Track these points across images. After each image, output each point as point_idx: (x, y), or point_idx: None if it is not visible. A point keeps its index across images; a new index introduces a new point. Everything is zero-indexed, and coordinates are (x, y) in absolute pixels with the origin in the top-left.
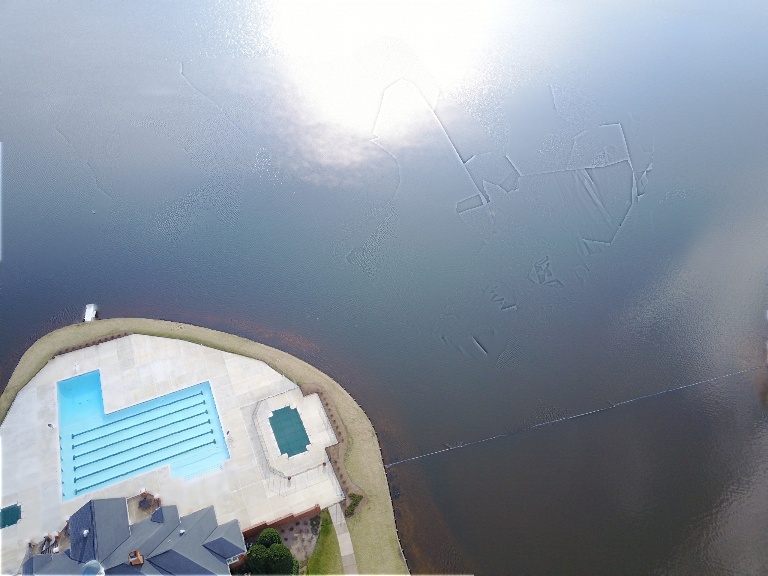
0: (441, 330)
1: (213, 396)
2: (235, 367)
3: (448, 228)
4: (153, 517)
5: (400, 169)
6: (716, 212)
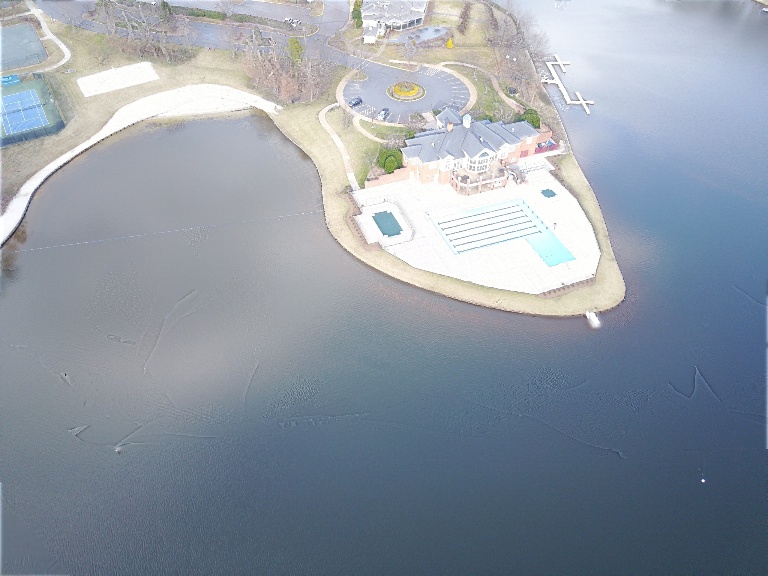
0: None
1: None
2: (436, 263)
3: None
4: None
5: (243, 404)
6: None
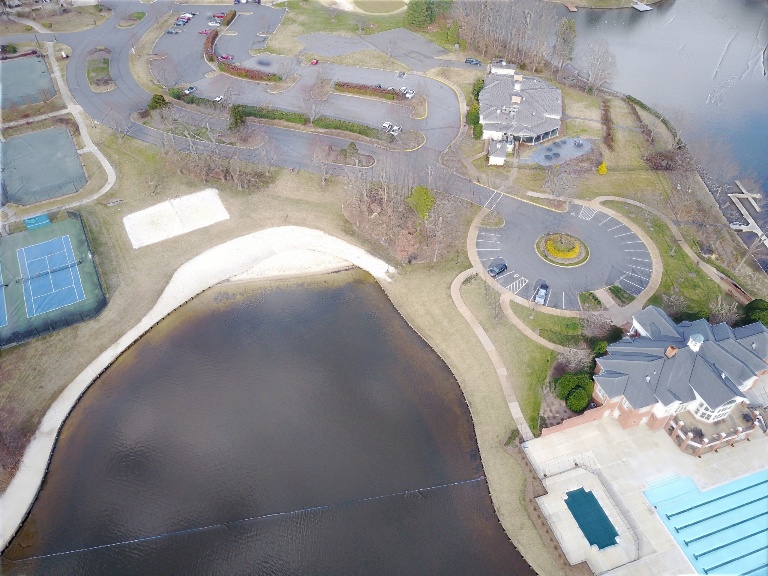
0: None
1: None
2: None
3: None
4: (679, 398)
5: None
6: None
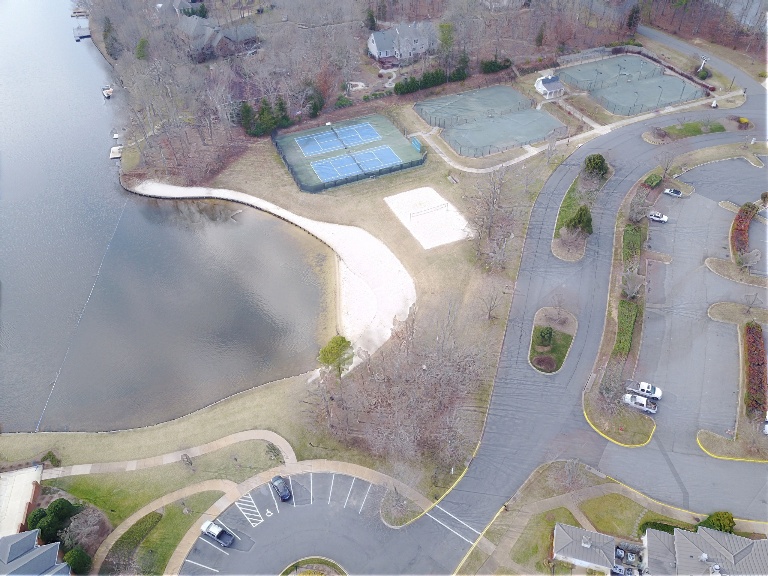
0: None
1: None
2: None
3: None
4: None
5: None
6: None
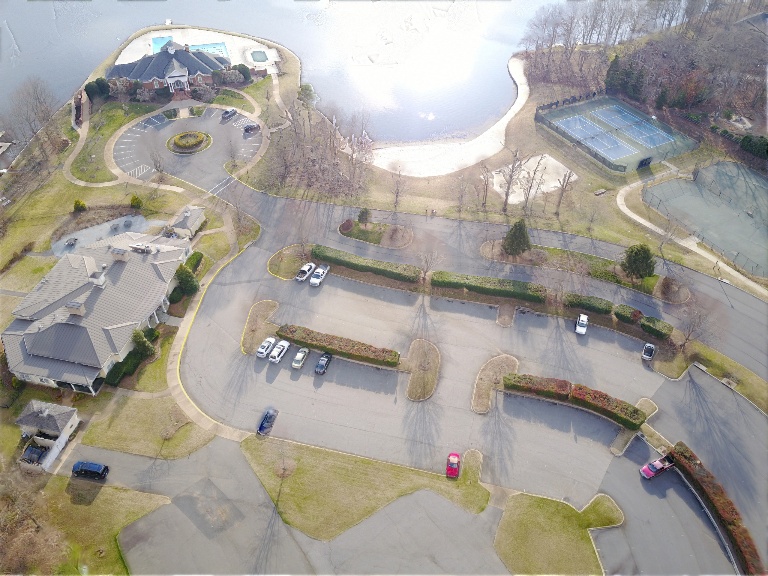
0: (351, 53)
1: (226, 46)
2: (238, 40)
3: (364, 6)
4: None
5: None
6: (513, 4)
